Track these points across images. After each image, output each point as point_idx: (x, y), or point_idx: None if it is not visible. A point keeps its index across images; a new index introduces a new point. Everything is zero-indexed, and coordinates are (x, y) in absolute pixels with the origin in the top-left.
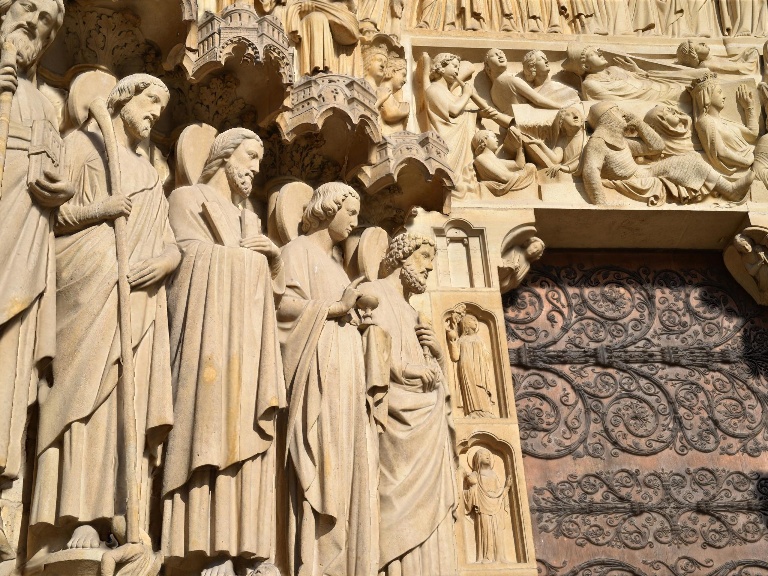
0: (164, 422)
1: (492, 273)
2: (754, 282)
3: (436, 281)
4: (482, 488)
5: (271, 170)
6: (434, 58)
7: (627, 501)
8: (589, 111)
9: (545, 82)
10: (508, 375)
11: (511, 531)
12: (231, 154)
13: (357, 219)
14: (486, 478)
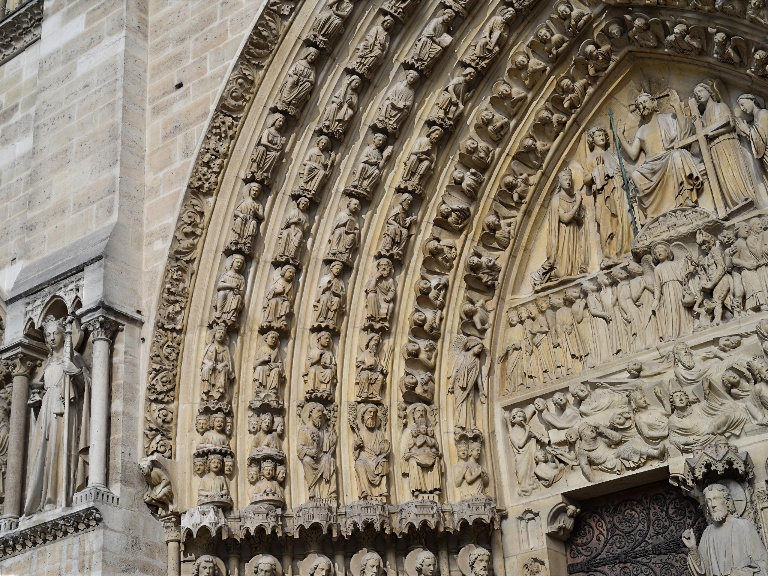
0: None
1: (543, 538)
2: None
3: (519, 548)
4: None
5: (408, 543)
6: None
7: None
8: None
9: None
10: None
11: None
12: (365, 568)
13: None
14: None
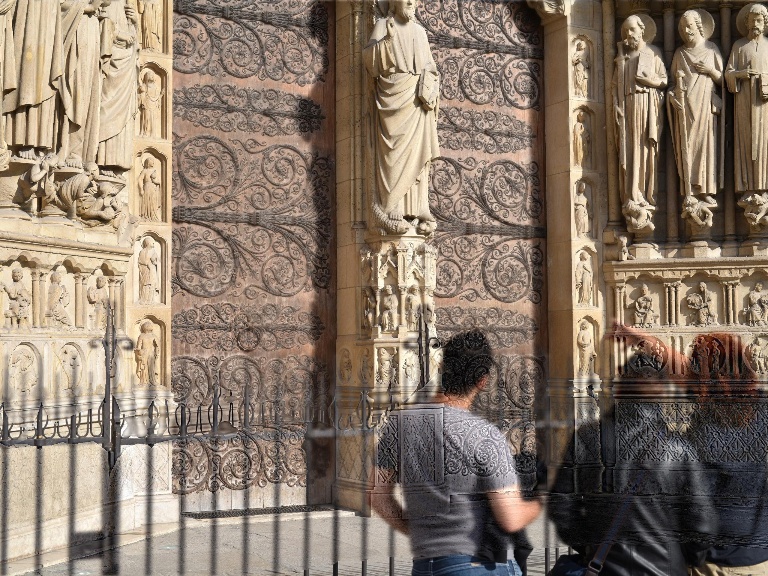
0: (13, 87)
1: None
2: None
3: None
4: (148, 95)
5: None
6: None
7: (226, 104)
8: None
9: None
10: (171, 28)
11: (161, 120)
12: None
13: None
14: (151, 89)
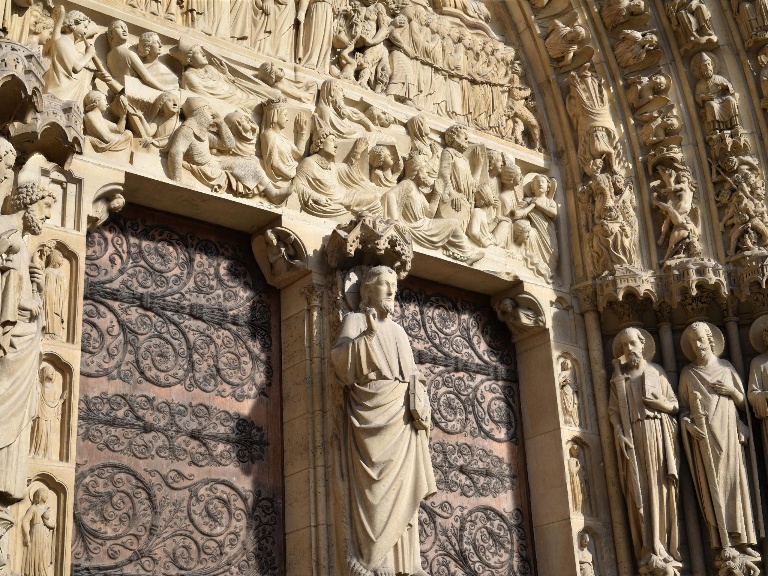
0: None
1: (83, 219)
2: (269, 266)
3: None
4: (44, 398)
5: None
6: (68, 13)
7: (142, 420)
8: (186, 101)
9: (154, 62)
10: (80, 309)
11: (59, 435)
12: None
13: (10, 172)
14: (48, 390)
